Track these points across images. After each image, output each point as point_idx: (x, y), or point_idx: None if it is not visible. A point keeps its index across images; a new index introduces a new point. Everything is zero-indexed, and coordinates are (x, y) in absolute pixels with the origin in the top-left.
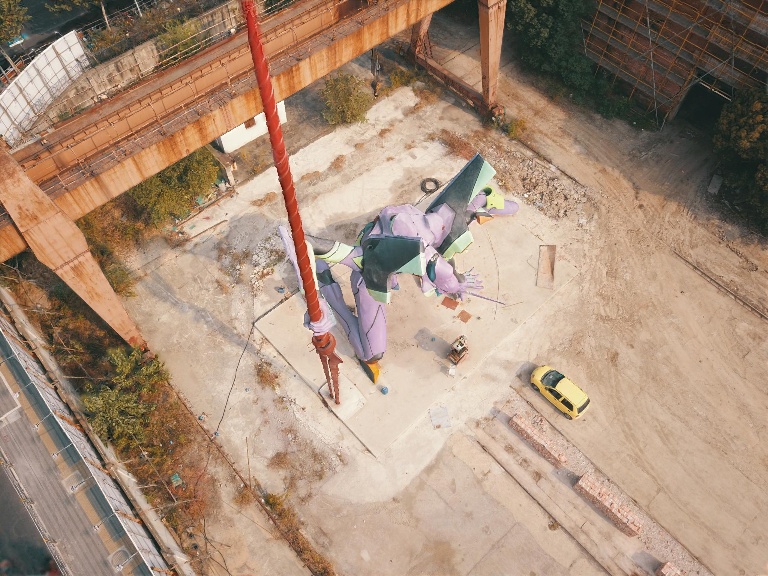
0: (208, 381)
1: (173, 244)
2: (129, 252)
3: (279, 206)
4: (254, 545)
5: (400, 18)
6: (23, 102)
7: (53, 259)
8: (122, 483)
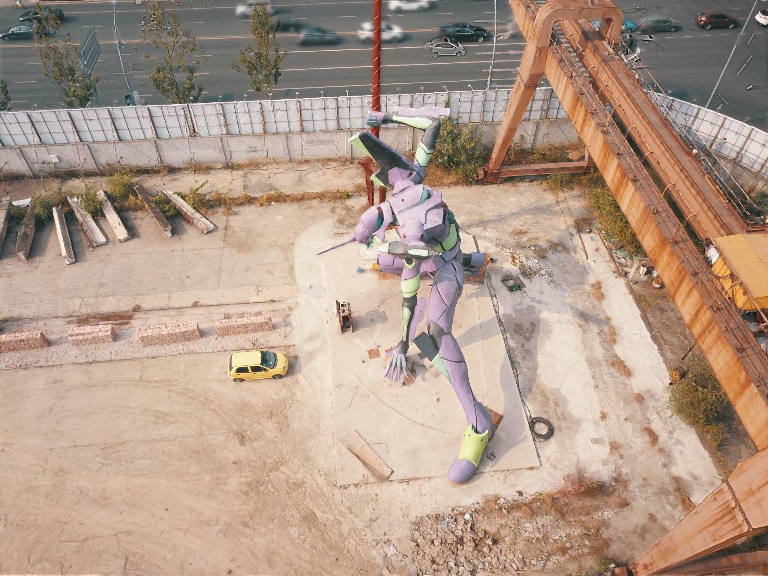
0: (447, 201)
1: (579, 222)
2: (584, 198)
3: (585, 297)
4: (331, 182)
5: (691, 303)
6: (766, 155)
7: (522, 67)
8: (400, 127)
